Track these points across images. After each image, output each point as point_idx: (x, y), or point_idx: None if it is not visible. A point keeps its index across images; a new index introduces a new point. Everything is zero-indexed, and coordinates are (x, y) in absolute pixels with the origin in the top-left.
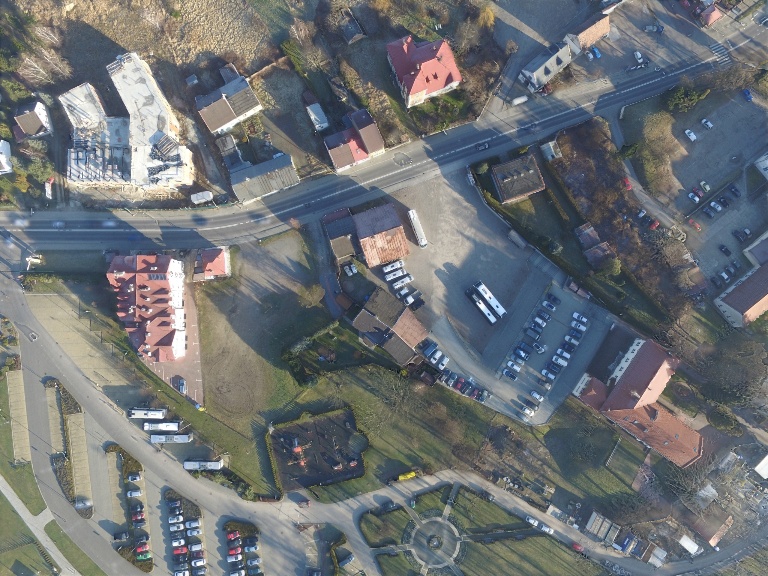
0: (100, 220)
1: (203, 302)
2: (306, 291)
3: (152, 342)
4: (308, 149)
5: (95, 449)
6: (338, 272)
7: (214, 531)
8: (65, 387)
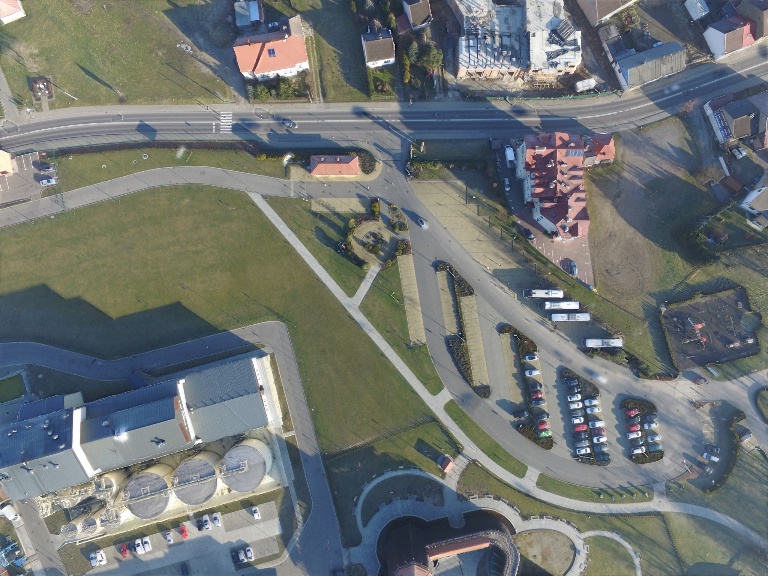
0: (479, 110)
1: (589, 187)
2: (690, 176)
3: (572, 216)
4: (685, 39)
5: (489, 330)
6: (728, 155)
7: (611, 409)
8: (457, 270)
